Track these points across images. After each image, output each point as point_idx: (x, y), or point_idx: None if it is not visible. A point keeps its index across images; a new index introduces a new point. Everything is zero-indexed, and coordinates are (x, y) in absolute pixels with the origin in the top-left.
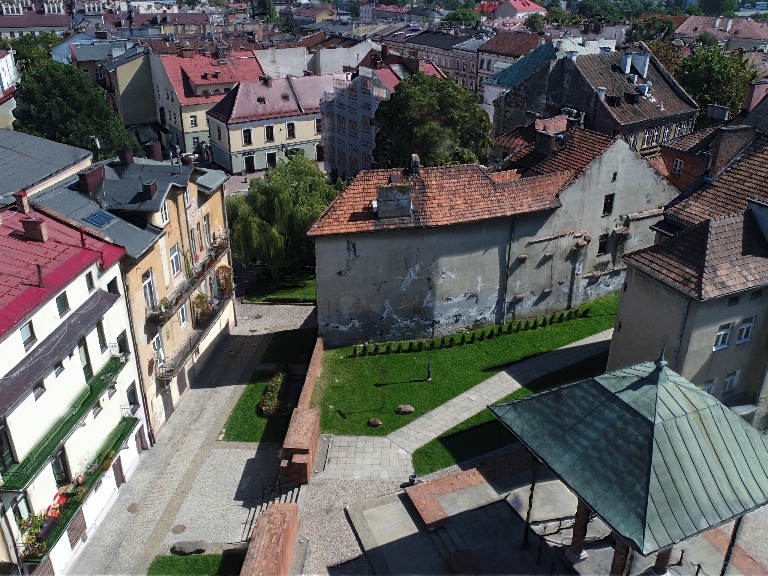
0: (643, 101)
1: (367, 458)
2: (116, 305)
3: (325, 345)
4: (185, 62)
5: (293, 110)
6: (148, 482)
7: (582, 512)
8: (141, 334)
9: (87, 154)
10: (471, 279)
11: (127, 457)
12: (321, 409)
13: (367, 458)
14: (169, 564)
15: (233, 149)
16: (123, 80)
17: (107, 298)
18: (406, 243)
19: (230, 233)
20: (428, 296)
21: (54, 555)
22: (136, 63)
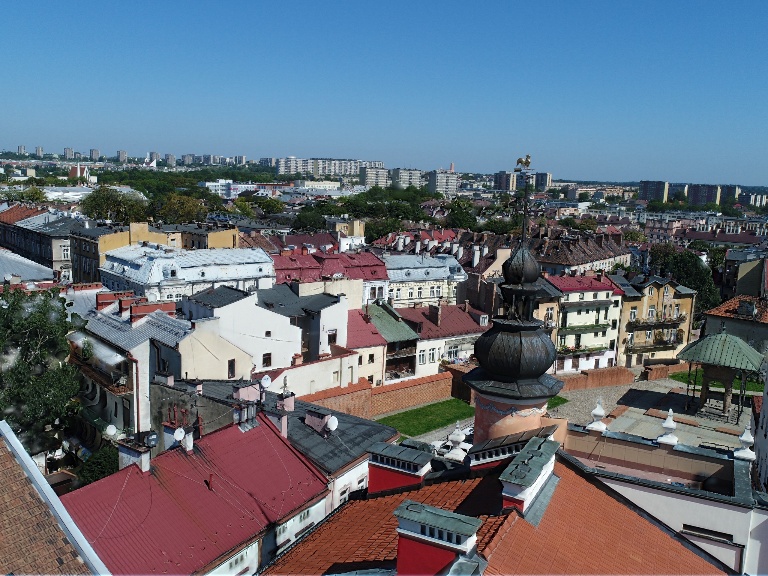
0: None
1: (675, 384)
2: (616, 309)
3: None
4: None
5: None
6: None
7: None
8: (624, 326)
9: None
10: None
11: (602, 362)
12: (676, 374)
13: (675, 384)
14: None
15: None
16: (742, 272)
17: (611, 302)
18: (749, 328)
19: None
20: None
21: (566, 363)
22: (754, 263)
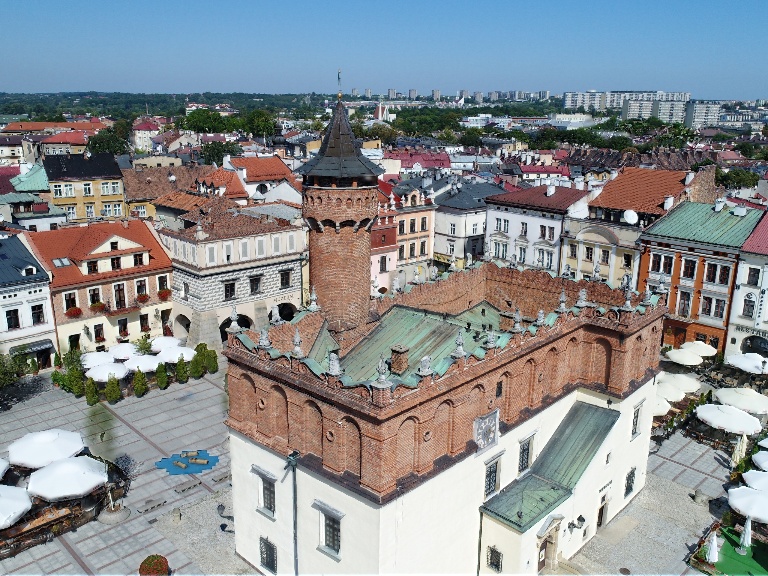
0: None
1: None
2: None
3: None
4: None
5: None
6: None
7: None
8: None
9: None
10: None
11: None
12: None
13: None
14: None
15: None
16: None
17: None
18: None
19: None
20: None
21: None
22: None
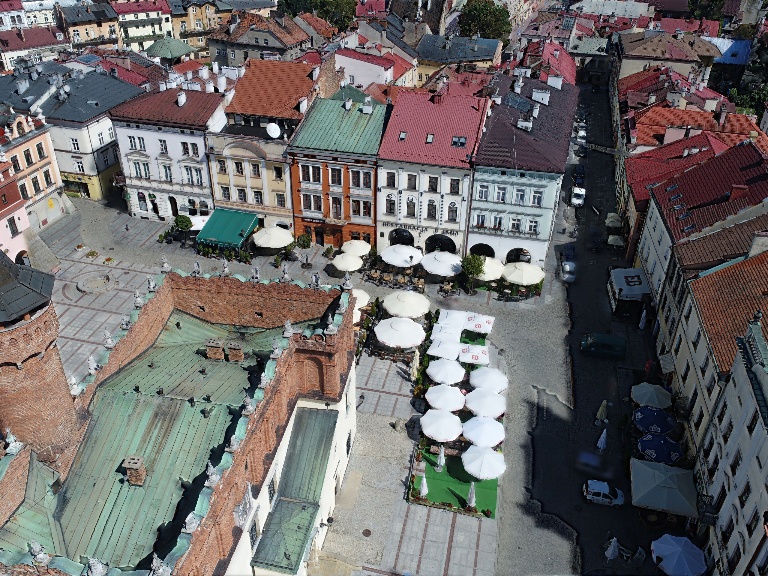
0: (413, 20)
1: None
2: (168, 23)
3: None
4: None
5: None
6: None
7: None
8: None
9: (274, 6)
10: None
11: None
12: None
13: None
14: None
15: None
16: None
17: (161, 19)
18: None
19: None
20: None
21: None
22: None
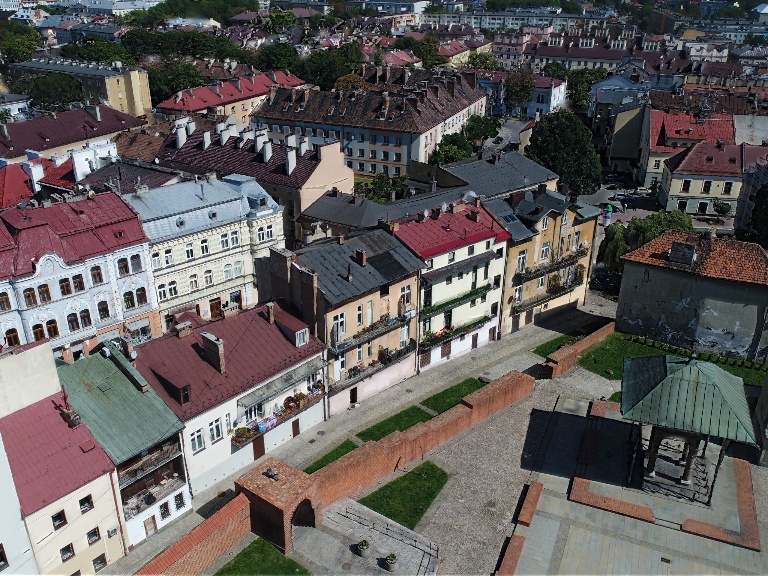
0: None
1: (590, 383)
2: (499, 261)
3: (617, 328)
4: (669, 117)
5: (735, 172)
6: (487, 352)
7: (653, 428)
8: (510, 281)
9: (555, 177)
10: (730, 321)
11: (482, 336)
12: (586, 355)
13: (590, 383)
14: (474, 382)
15: (671, 193)
16: (620, 123)
17: (493, 255)
18: (684, 281)
19: (606, 249)
20: (693, 321)
21: (433, 354)
22: (634, 112)
